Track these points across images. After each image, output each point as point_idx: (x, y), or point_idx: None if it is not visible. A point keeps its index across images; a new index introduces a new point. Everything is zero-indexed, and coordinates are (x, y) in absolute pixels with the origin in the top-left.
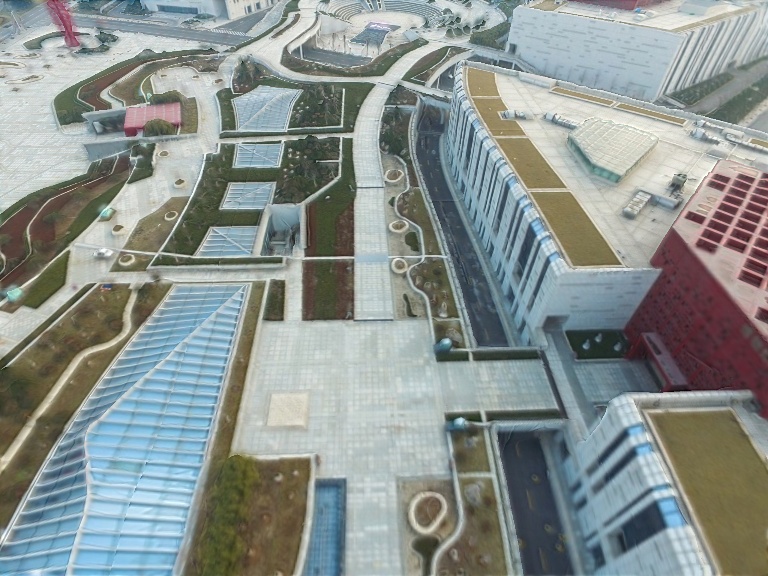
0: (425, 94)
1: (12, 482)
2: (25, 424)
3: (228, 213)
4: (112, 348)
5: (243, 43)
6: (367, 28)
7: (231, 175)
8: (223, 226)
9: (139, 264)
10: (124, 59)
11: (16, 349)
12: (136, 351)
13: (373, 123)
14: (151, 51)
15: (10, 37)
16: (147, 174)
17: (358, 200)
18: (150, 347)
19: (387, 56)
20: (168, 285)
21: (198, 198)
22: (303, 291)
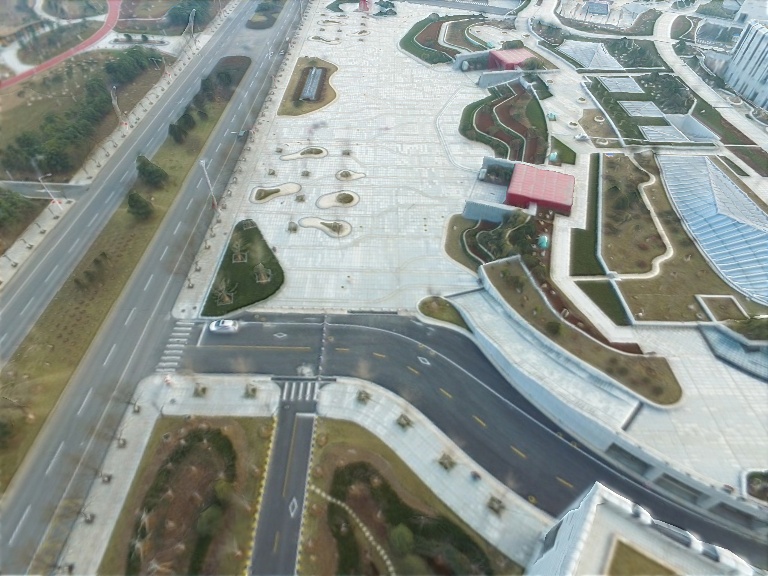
0: (703, 49)
1: (679, 238)
2: (651, 215)
3: (640, 118)
4: (656, 184)
5: (518, 9)
6: (587, 2)
7: (615, 96)
8: (646, 125)
9: (612, 144)
10: (415, 21)
11: (592, 183)
12: (675, 186)
13: (683, 67)
14: (437, 15)
15: (309, 2)
16: (549, 94)
17: (723, 115)
18: (685, 183)
19: (643, 21)
20: (653, 155)
21: (607, 109)
22: (745, 162)
